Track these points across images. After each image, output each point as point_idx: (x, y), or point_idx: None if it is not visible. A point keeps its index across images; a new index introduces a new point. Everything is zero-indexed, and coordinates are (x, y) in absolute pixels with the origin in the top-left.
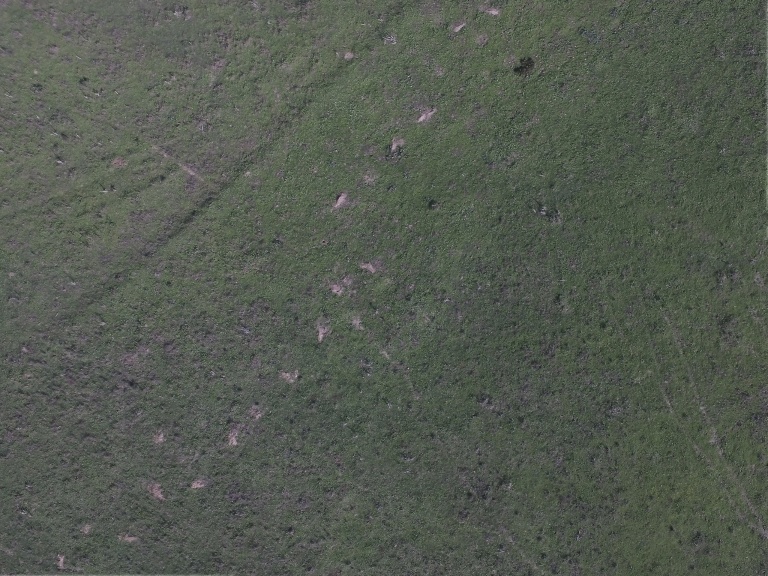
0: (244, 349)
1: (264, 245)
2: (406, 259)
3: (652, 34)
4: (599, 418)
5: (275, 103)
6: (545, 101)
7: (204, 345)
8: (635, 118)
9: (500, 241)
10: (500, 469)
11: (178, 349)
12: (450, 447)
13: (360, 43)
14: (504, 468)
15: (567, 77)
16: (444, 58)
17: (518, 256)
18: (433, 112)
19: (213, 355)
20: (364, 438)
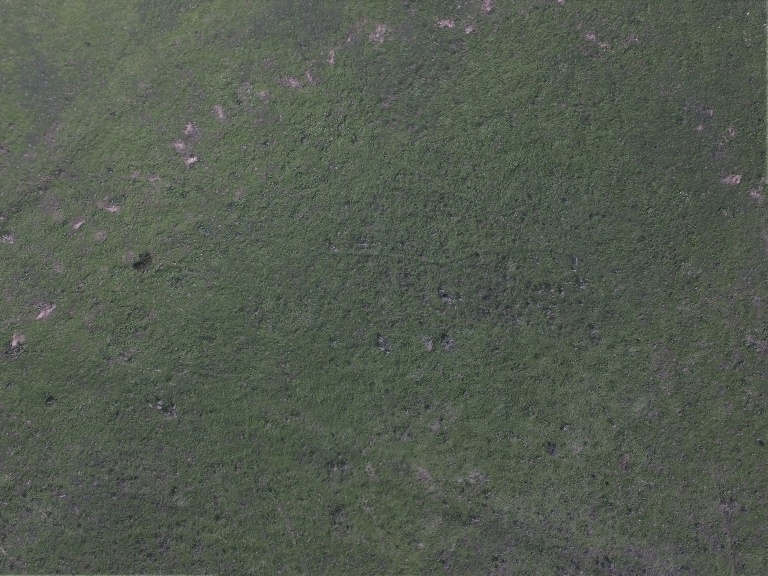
0: None
1: None
2: (24, 455)
3: (268, 228)
4: None
5: None
6: (161, 297)
7: None
8: (251, 311)
9: (117, 435)
10: None
11: None
12: None
13: None
14: None
15: (183, 273)
16: (60, 257)
17: (135, 450)
18: (52, 309)
19: None
20: None
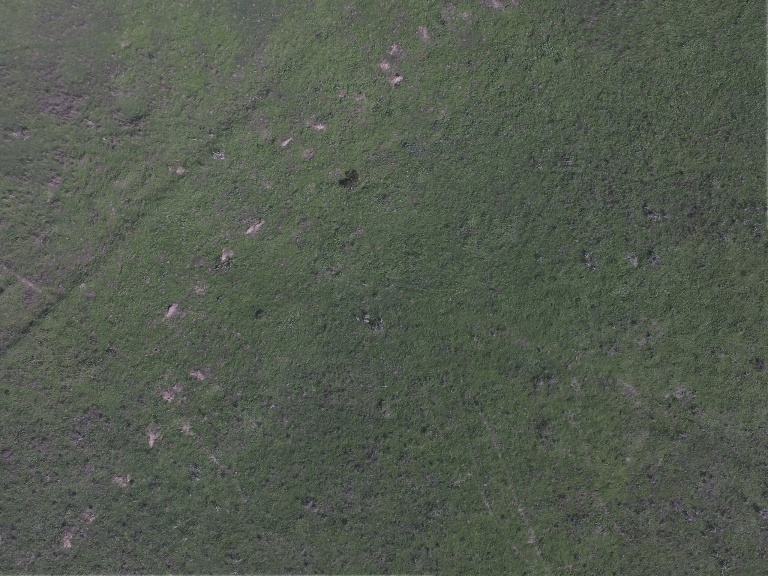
0: (78, 454)
1: (98, 354)
2: (234, 366)
3: (472, 146)
4: (420, 520)
5: (110, 216)
6: (368, 212)
7: (40, 451)
8: (456, 228)
9: (325, 348)
10: (325, 569)
11: (15, 455)
12: (277, 548)
13: (192, 157)
14: (329, 569)
15: (389, 189)
16: (270, 172)
17: (342, 363)
18: (261, 224)
19: (49, 460)
20: (194, 540)
